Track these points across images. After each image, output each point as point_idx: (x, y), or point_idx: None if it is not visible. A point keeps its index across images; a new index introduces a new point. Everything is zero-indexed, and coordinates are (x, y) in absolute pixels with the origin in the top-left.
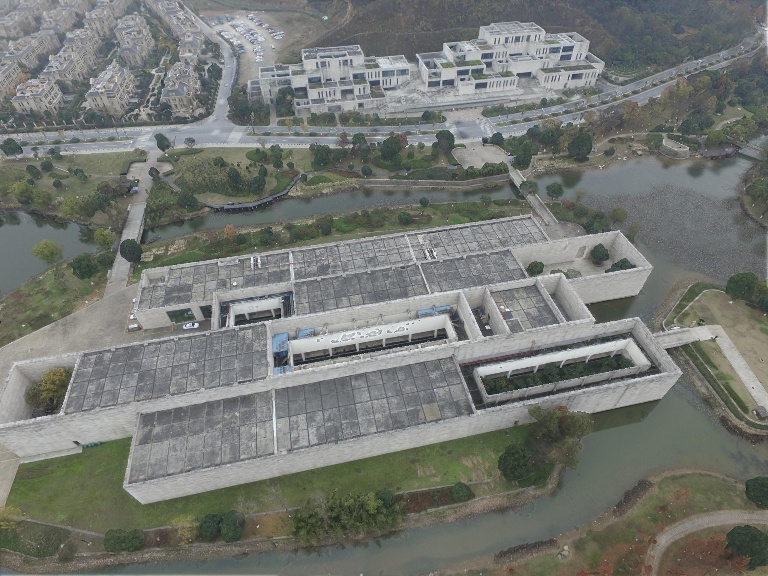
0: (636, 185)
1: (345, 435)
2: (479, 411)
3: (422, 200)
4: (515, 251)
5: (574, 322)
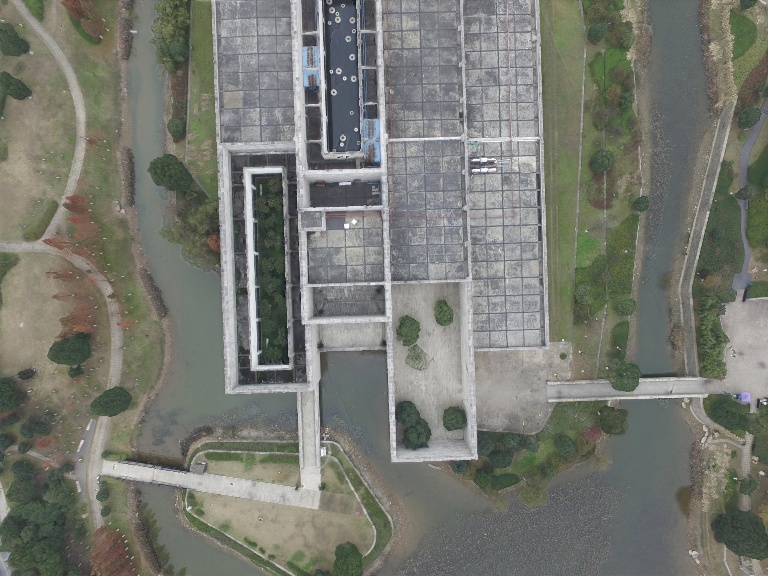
0: None
1: (223, 3)
2: (221, 147)
3: (642, 198)
4: (466, 287)
5: (304, 295)
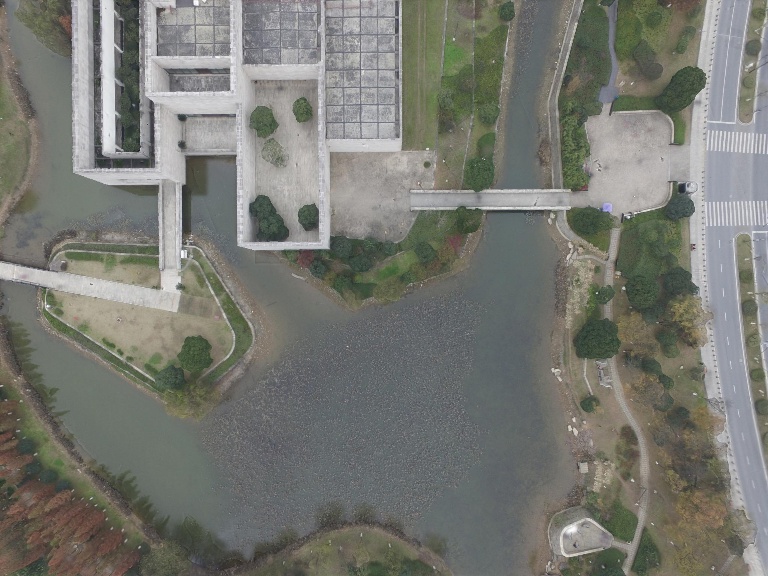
0: (491, 401)
1: None
2: None
3: (507, 2)
4: None
5: (148, 67)
